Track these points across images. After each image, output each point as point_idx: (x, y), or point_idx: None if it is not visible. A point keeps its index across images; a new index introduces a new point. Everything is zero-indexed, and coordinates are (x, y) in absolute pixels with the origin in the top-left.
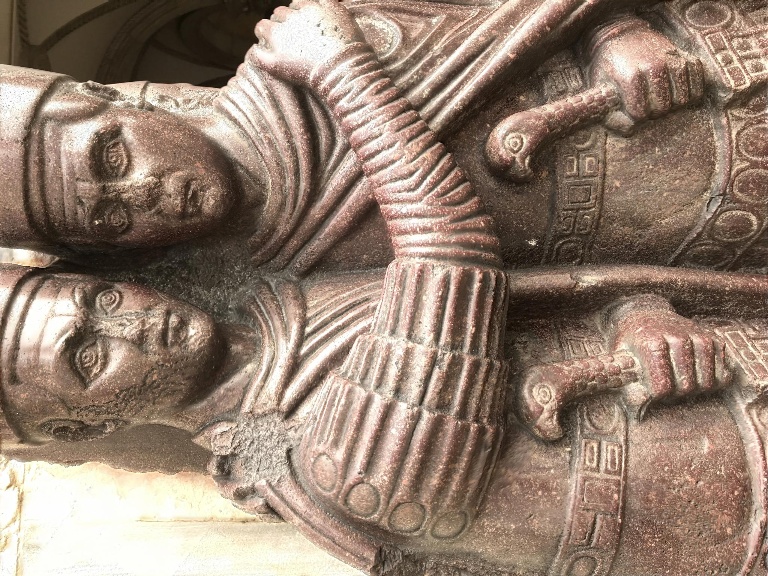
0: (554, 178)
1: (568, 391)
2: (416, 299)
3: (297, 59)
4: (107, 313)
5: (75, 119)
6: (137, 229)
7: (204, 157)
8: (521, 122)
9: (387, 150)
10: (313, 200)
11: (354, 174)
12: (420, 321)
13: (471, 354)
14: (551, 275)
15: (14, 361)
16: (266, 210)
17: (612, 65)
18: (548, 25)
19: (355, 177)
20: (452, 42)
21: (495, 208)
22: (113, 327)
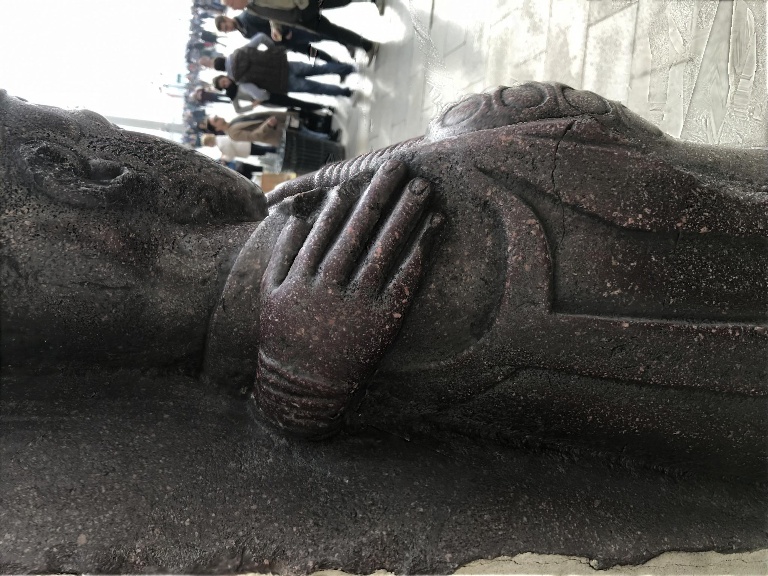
0: None
1: None
2: None
3: None
4: None
5: None
6: None
7: None
8: None
9: None
10: None
11: None
12: None
13: None
14: None
15: None
16: None
17: None
18: None
19: None
20: None
21: None
22: None
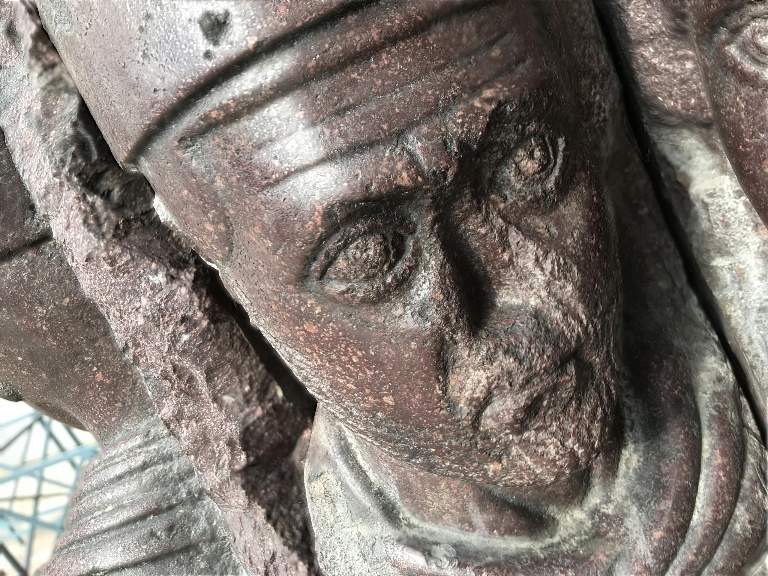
0: None
1: None
2: None
3: None
4: None
5: None
6: None
7: None
8: None
9: None
10: None
11: None
12: None
13: None
14: None
15: None
16: None
17: None
18: None
19: None
20: None
21: None
22: None
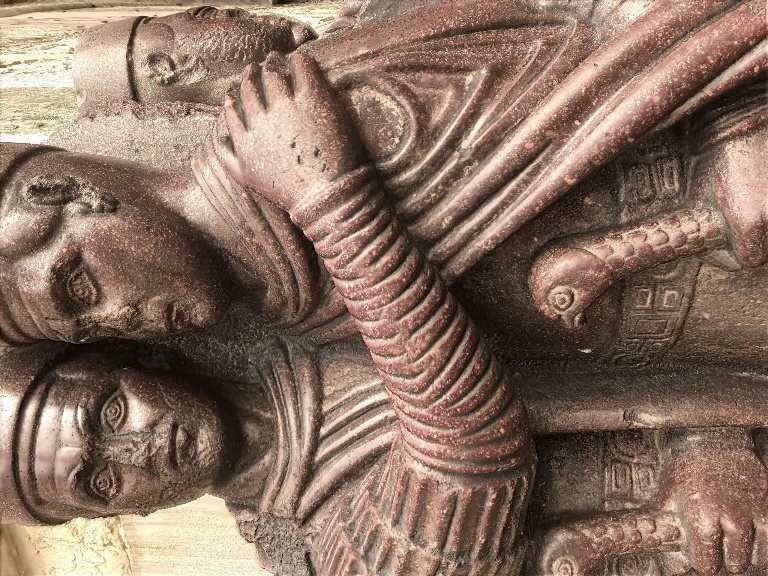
0: (618, 308)
1: (593, 566)
2: (419, 507)
3: (270, 191)
4: (114, 430)
5: (26, 252)
6: (129, 336)
7: (183, 271)
8: (573, 273)
9: (385, 340)
10: (318, 303)
11: None
12: (424, 525)
13: (479, 560)
14: (600, 411)
15: (35, 489)
16: (268, 300)
17: (724, 192)
18: (631, 136)
19: None
20: (488, 138)
21: (539, 326)
22: (120, 454)
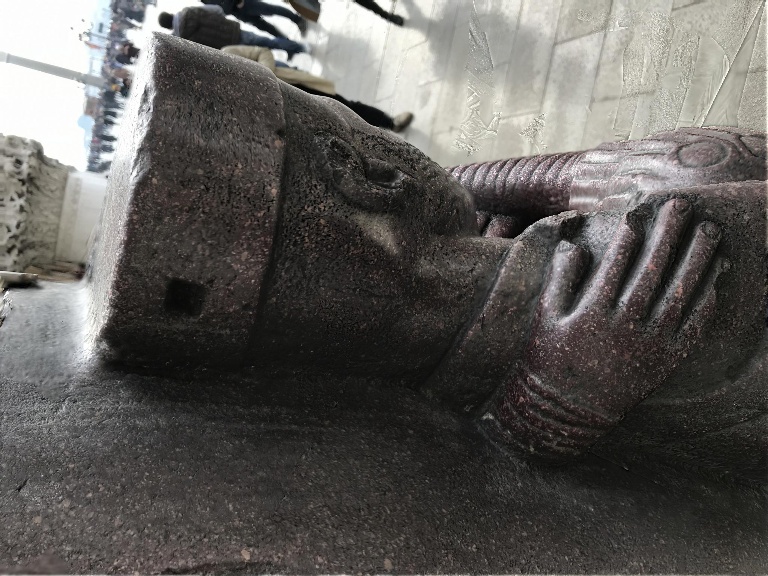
0: None
1: None
2: None
3: None
4: None
5: None
6: None
7: None
8: None
9: None
10: None
11: (480, 222)
12: None
13: None
14: None
15: None
16: None
17: None
18: None
19: (482, 225)
20: None
21: None
22: None
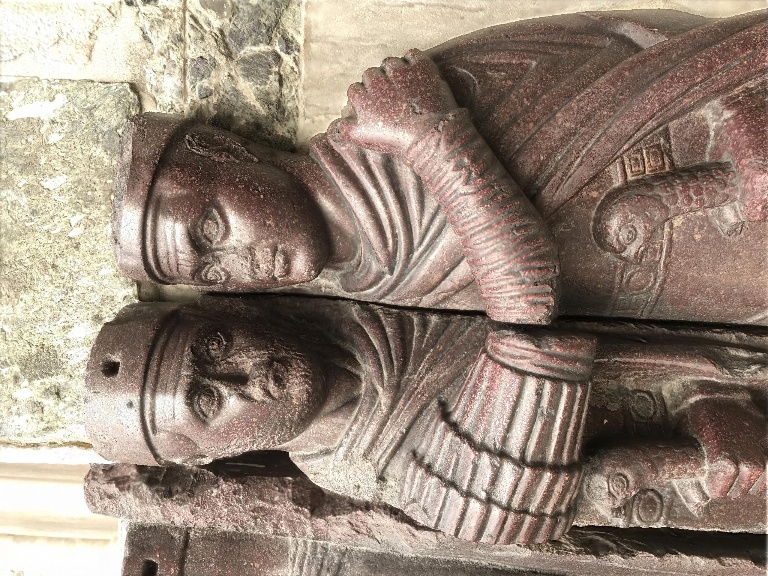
0: None
1: None
2: None
3: None
4: None
5: None
6: None
7: None
8: None
9: None
10: None
11: None
12: None
13: None
14: None
15: None
16: None
17: None
18: None
19: None
20: None
21: None
22: None
